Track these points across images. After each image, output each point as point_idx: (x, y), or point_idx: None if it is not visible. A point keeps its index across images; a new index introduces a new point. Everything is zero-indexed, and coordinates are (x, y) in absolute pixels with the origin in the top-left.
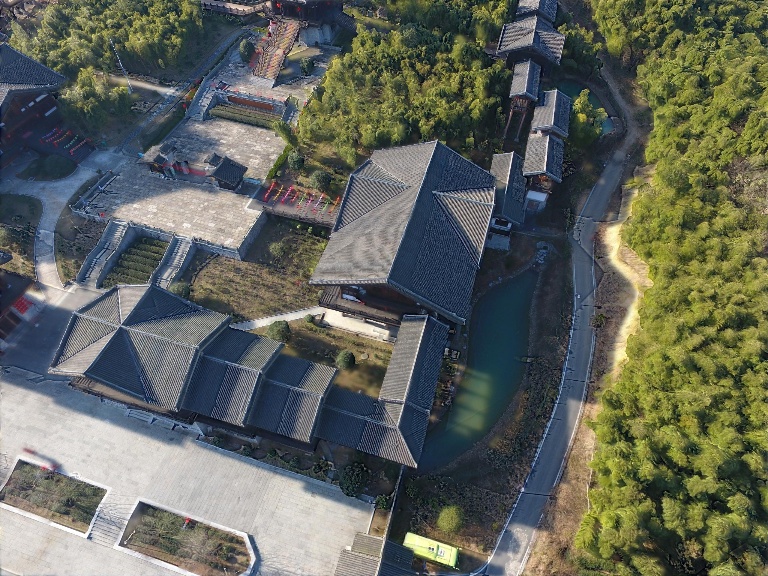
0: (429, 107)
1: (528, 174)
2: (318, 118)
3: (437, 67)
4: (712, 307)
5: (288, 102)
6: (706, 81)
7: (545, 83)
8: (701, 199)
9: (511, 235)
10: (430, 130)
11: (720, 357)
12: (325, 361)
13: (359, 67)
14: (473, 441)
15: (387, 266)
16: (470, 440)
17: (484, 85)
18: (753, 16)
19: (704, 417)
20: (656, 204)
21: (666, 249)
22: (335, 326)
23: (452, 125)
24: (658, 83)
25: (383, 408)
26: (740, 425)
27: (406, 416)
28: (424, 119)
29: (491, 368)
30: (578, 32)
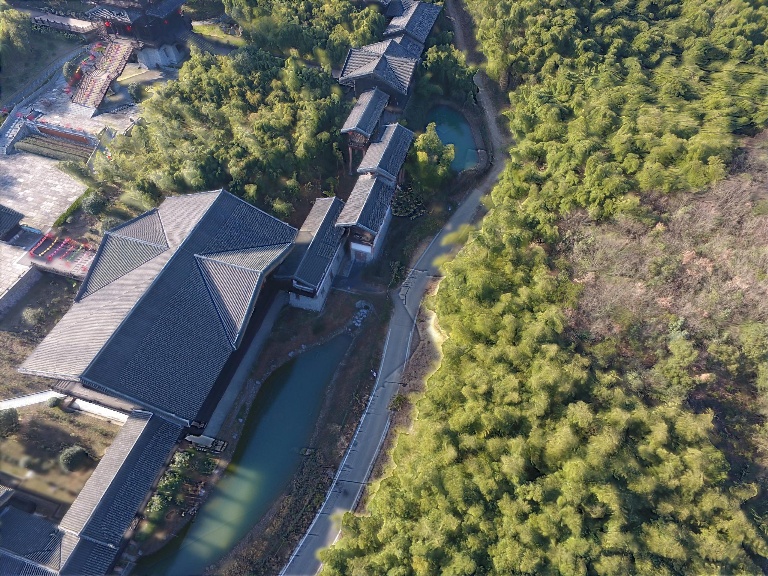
0: (246, 144)
1: (340, 225)
2: (134, 153)
3: (270, 96)
4: (480, 409)
5: (103, 134)
6: (571, 113)
7: (398, 113)
8: (515, 262)
9: (329, 292)
10: (241, 171)
11: (475, 476)
12: (57, 457)
13: (177, 96)
14: (207, 564)
15: (91, 357)
16: (205, 562)
17: (320, 117)
18: (641, 38)
19: (440, 558)
20: (466, 267)
21: (457, 327)
22: (86, 410)
23: (271, 165)
24: (516, 116)
25: (59, 541)
26: (485, 568)
27: (79, 554)
28: (235, 159)
29: (263, 462)
30: (451, 54)
